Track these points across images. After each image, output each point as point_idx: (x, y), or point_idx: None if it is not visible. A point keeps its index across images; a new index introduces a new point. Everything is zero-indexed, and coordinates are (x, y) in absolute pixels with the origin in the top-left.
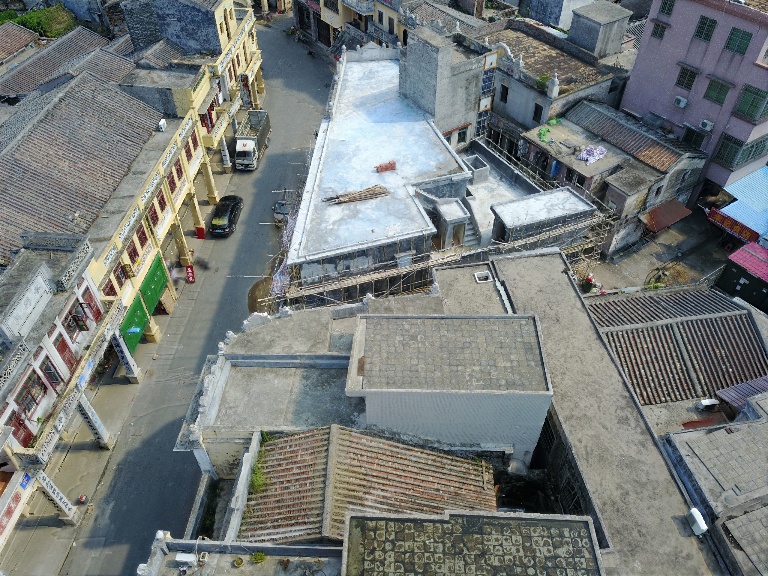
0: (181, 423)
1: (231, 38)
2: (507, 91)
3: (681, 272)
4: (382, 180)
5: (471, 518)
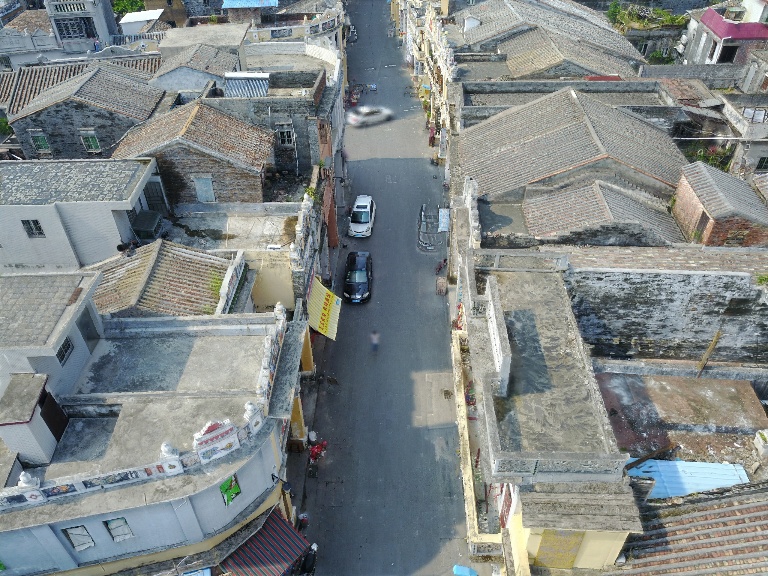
0: (393, 558)
1: None
2: None
3: None
4: None
5: None
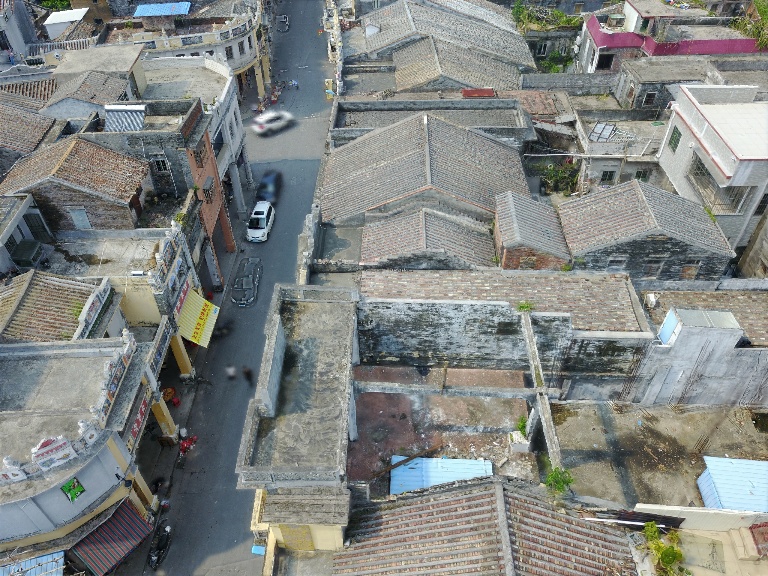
0: (236, 536)
1: None
2: None
3: None
4: None
5: None
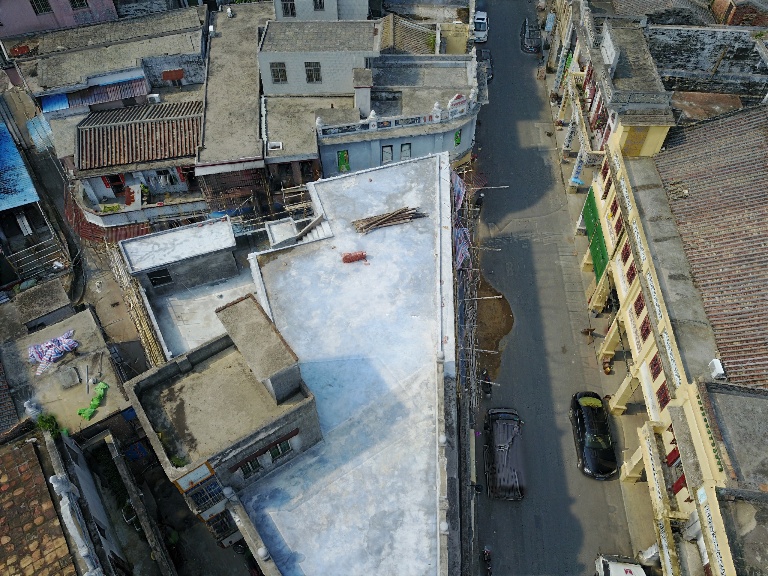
0: (524, 206)
1: None
2: None
3: None
4: (360, 243)
5: None
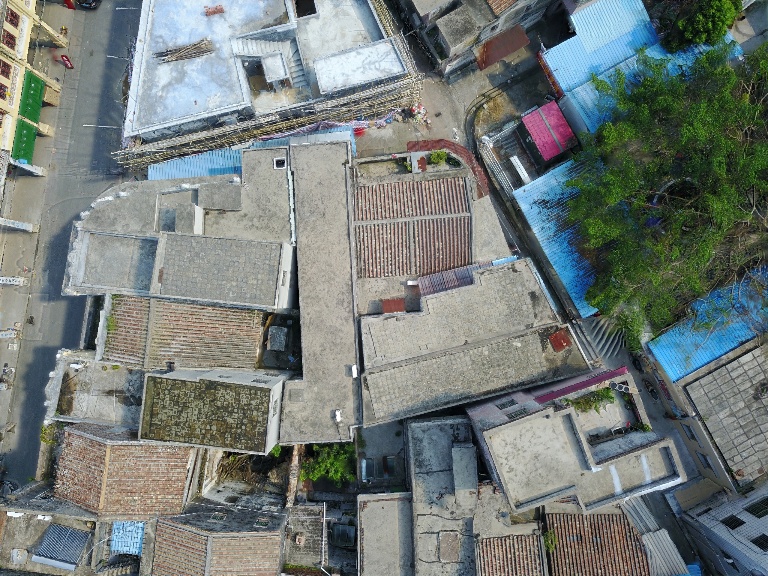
0: None
1: None
2: None
3: (499, 106)
4: (210, 29)
5: (211, 381)
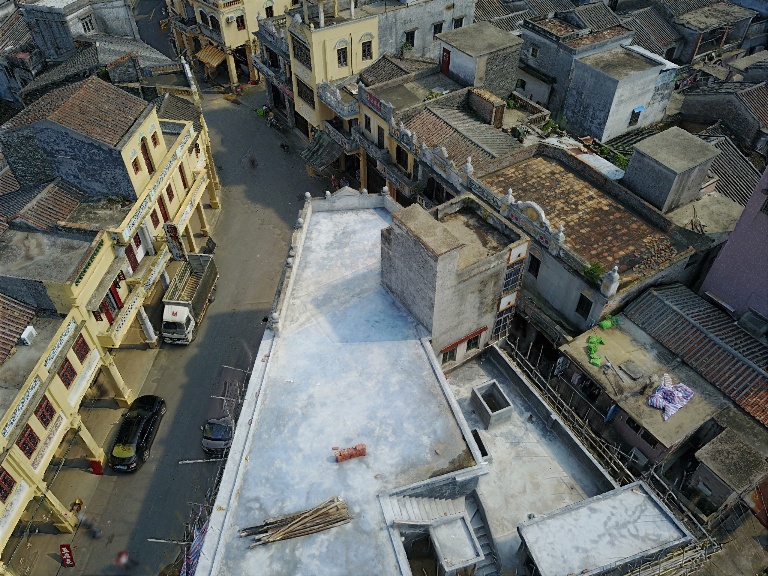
0: None
1: (155, 171)
2: (538, 264)
3: None
4: (342, 482)
5: None
